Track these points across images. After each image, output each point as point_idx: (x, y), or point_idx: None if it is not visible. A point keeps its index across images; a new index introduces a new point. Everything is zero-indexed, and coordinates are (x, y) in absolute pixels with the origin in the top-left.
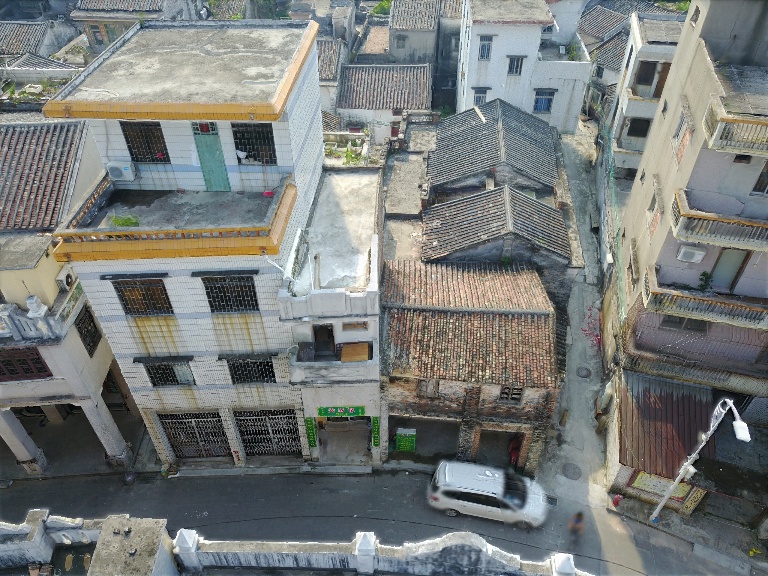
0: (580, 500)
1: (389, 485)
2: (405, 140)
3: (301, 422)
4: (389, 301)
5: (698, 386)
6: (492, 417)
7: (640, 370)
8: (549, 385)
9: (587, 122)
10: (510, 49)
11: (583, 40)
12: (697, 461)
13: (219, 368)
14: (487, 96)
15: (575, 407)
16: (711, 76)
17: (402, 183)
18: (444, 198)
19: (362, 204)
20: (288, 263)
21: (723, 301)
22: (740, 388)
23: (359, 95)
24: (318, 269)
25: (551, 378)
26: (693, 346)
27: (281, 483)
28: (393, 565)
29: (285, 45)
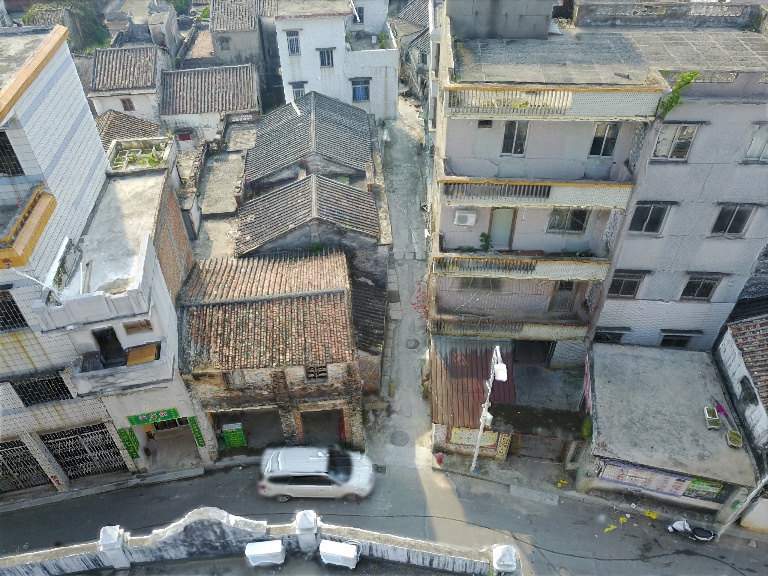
0: (407, 464)
1: (222, 483)
2: (223, 140)
3: (115, 435)
4: (188, 300)
5: (499, 340)
6: (305, 398)
7: (446, 333)
8: (347, 358)
9: (420, 107)
10: (318, 42)
11: (407, 29)
12: (498, 408)
13: (4, 392)
14: (305, 90)
15: (404, 378)
16: (447, 50)
17: (220, 183)
18: (261, 193)
19: (144, 206)
20: (49, 273)
21: (497, 257)
22: (534, 336)
23: (182, 100)
24: (88, 276)
25: (349, 351)
26: (483, 303)
27: (109, 501)
28: (147, 554)
29: (25, 51)
